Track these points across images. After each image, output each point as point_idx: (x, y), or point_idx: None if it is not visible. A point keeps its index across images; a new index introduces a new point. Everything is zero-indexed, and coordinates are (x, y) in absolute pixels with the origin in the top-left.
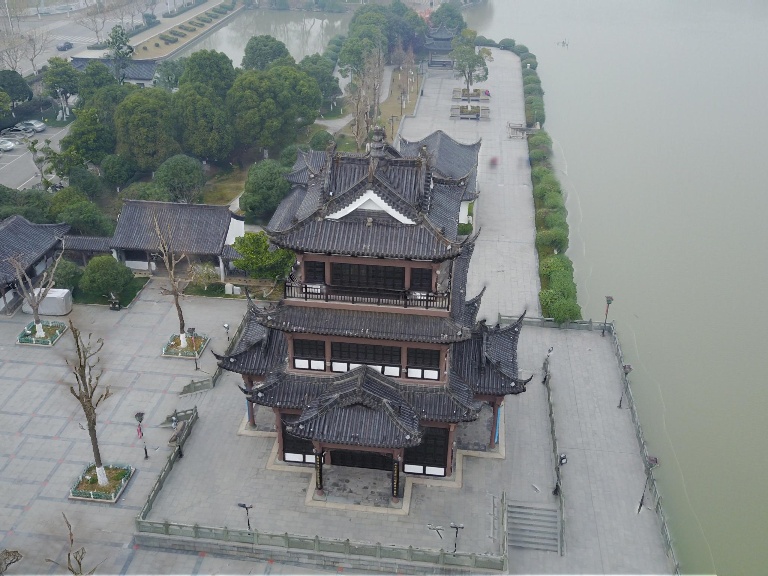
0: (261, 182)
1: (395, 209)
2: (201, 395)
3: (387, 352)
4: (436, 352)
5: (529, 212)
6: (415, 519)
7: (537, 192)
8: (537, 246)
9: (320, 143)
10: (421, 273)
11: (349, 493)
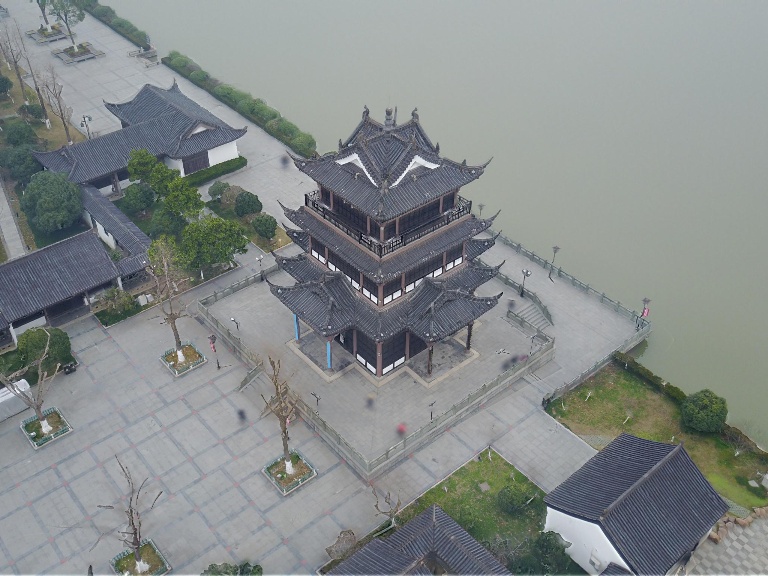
0: (60, 196)
1: (429, 162)
2: (261, 379)
3: (435, 261)
4: (461, 245)
5: (254, 128)
6: (486, 355)
7: (246, 109)
8: (301, 153)
9: (23, 137)
10: (448, 197)
11: (440, 366)
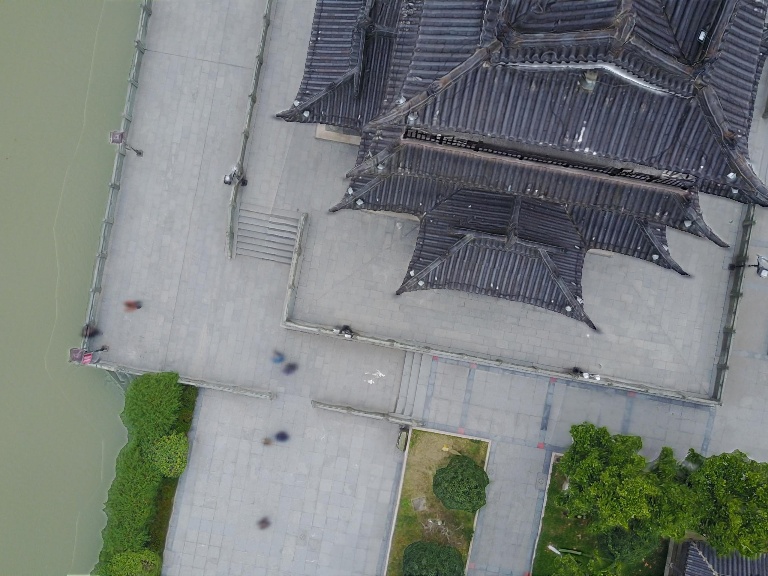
0: None
1: None
2: (766, 179)
3: None
4: None
5: None
6: None
7: None
8: None
9: None
10: None
11: None
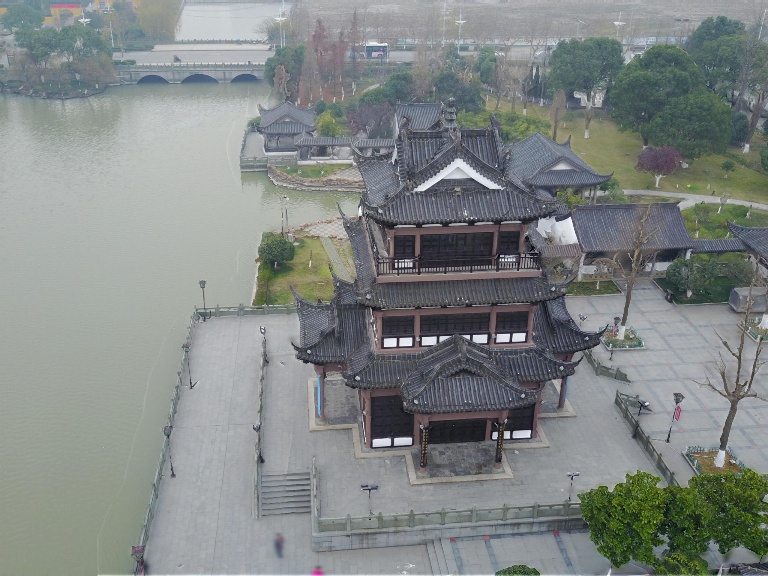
0: None
1: None
2: None
3: None
4: None
5: None
6: None
7: None
8: None
9: None
10: None
11: None
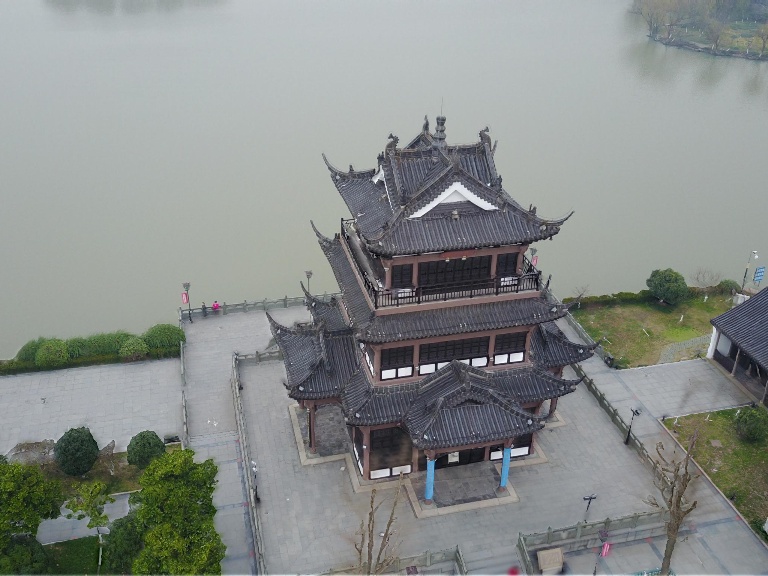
0: None
1: None
2: (473, 569)
3: None
4: None
5: None
6: None
7: None
8: None
9: None
10: None
11: None
